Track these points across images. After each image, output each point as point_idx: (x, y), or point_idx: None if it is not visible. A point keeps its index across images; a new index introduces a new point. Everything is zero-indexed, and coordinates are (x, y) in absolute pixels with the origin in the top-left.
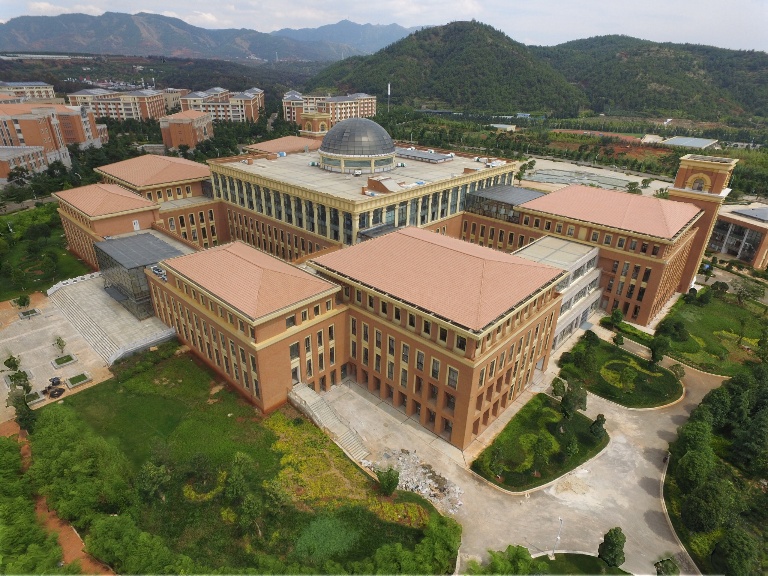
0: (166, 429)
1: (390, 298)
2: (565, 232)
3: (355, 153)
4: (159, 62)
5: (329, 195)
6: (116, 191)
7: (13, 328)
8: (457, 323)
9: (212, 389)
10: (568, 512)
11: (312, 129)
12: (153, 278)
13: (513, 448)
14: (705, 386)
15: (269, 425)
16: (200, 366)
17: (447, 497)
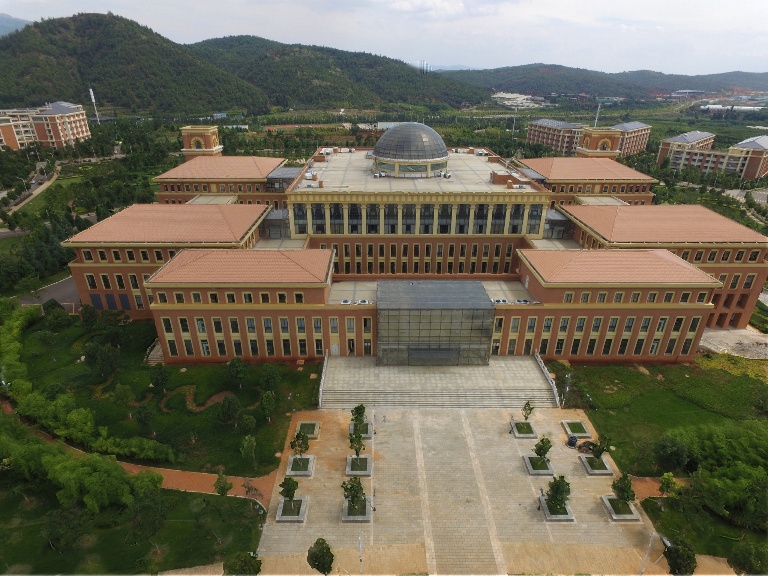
0: (691, 407)
1: (708, 244)
2: (585, 191)
3: (438, 156)
4: (422, 71)
5: (517, 193)
6: None
7: (389, 449)
8: (762, 242)
9: (642, 372)
10: None
11: (205, 146)
12: (514, 308)
13: None
14: None
15: (708, 367)
16: (600, 365)
17: None
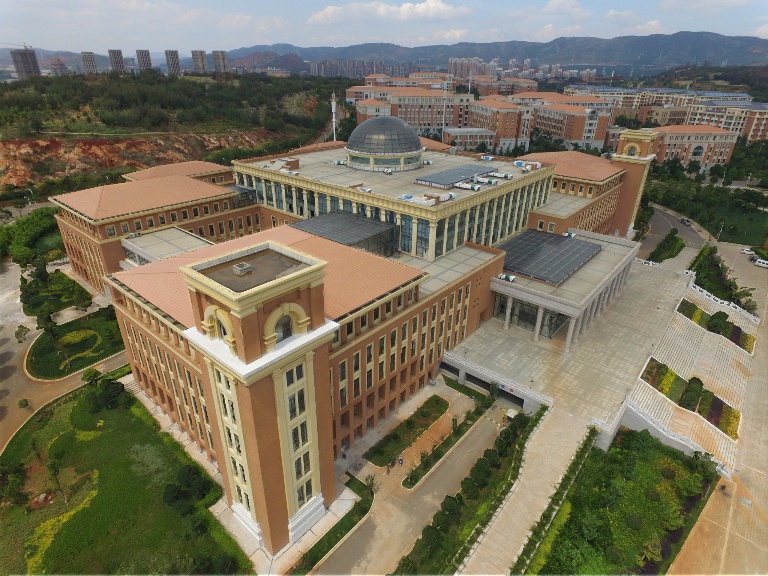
0: None
1: None
2: None
3: None
4: None
5: None
6: (331, 145)
7: None
8: None
9: None
10: (3, 291)
11: None
12: None
13: (57, 282)
14: (23, 396)
15: None
16: None
17: (50, 265)
